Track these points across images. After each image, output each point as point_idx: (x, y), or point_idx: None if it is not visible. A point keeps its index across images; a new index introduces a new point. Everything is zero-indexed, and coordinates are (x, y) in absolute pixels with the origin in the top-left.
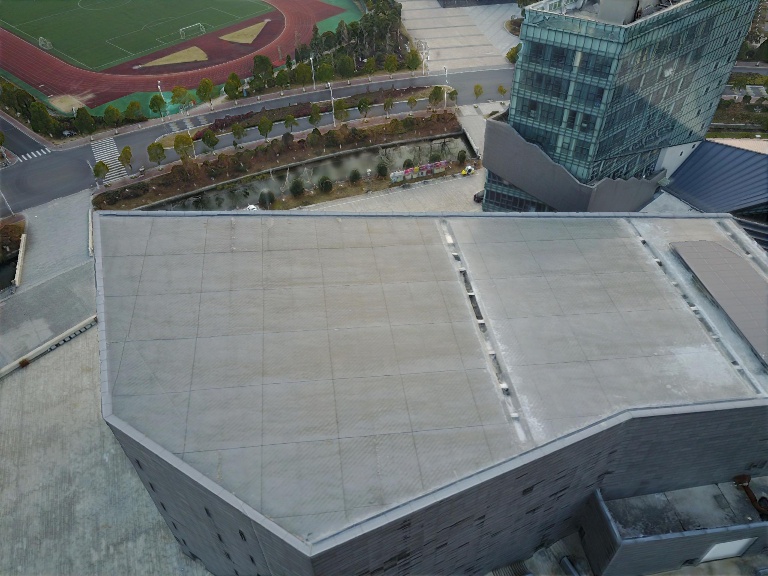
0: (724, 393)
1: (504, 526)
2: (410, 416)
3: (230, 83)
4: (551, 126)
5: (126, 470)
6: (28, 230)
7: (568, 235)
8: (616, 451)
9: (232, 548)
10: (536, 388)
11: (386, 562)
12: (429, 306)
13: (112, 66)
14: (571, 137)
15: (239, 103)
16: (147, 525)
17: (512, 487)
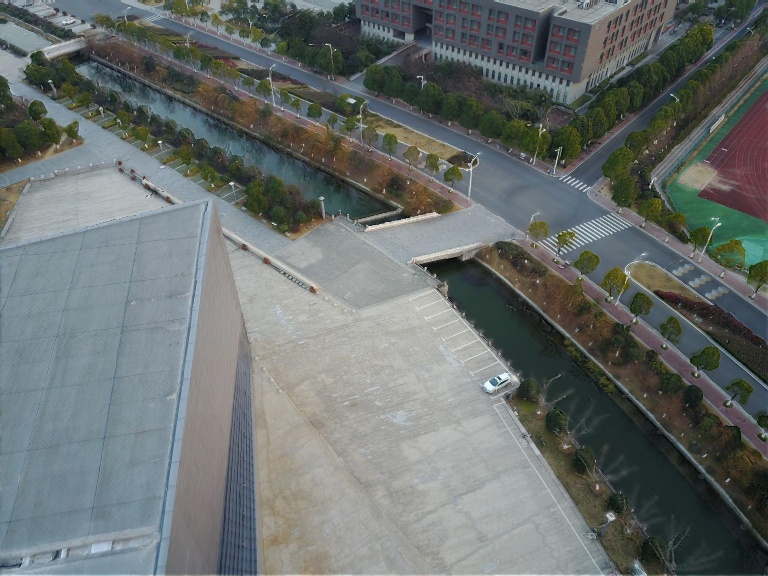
0: None
1: None
2: None
3: None
4: None
5: None
6: (448, 215)
7: None
8: None
9: None
10: None
11: None
12: None
13: None
14: None
15: None
16: None
17: None
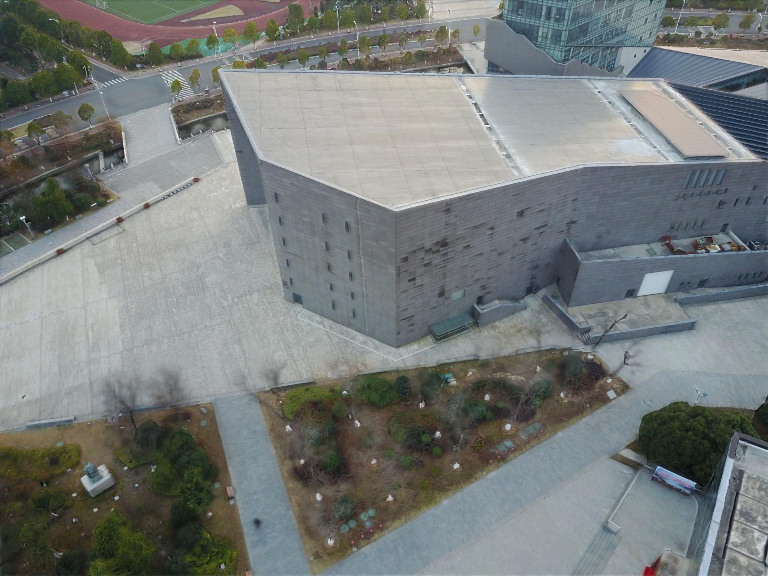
0: (645, 159)
1: (505, 248)
2: (446, 163)
3: (271, 26)
4: (534, 20)
5: (236, 261)
6: (125, 130)
7: (546, 87)
8: (576, 200)
9: (334, 252)
10: (524, 154)
11: (434, 244)
12: (453, 118)
13: (163, 20)
14: (548, 27)
15: (277, 44)
16: (258, 287)
17: (510, 204)
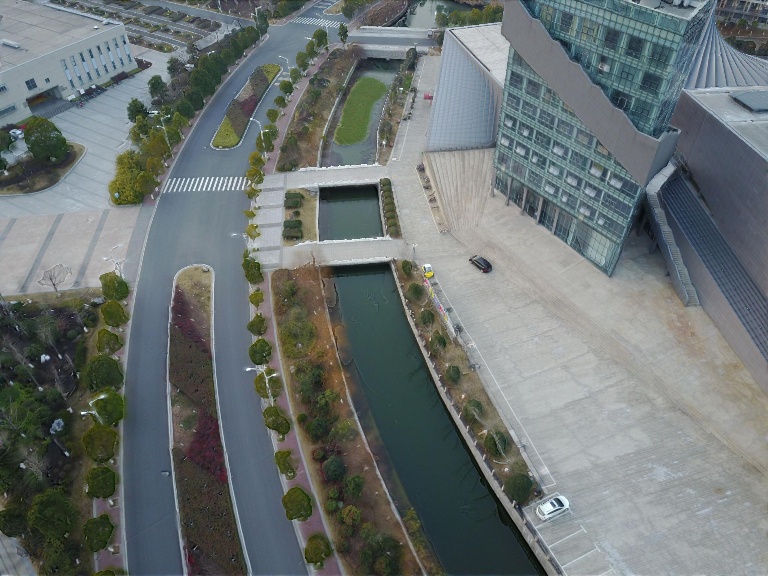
0: None
1: None
2: None
3: None
4: None
5: None
6: None
7: None
8: None
9: None
10: None
11: None
12: None
13: None
14: None
15: None
16: None
17: None
